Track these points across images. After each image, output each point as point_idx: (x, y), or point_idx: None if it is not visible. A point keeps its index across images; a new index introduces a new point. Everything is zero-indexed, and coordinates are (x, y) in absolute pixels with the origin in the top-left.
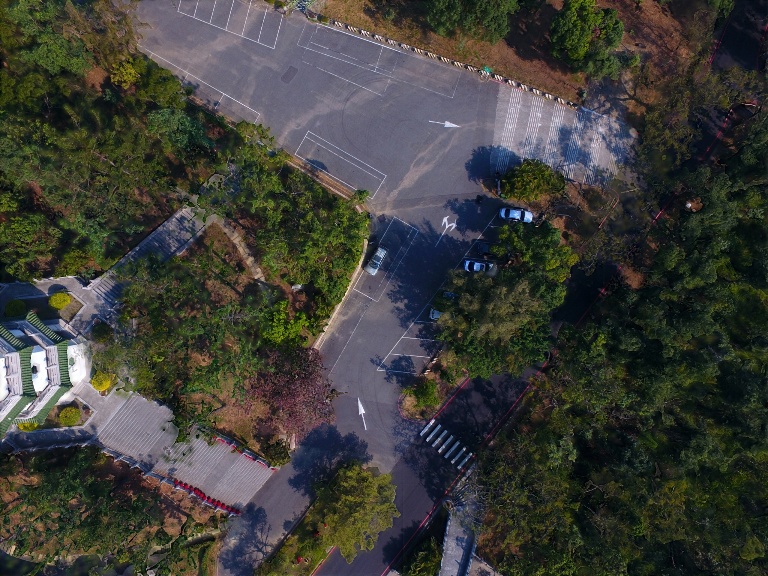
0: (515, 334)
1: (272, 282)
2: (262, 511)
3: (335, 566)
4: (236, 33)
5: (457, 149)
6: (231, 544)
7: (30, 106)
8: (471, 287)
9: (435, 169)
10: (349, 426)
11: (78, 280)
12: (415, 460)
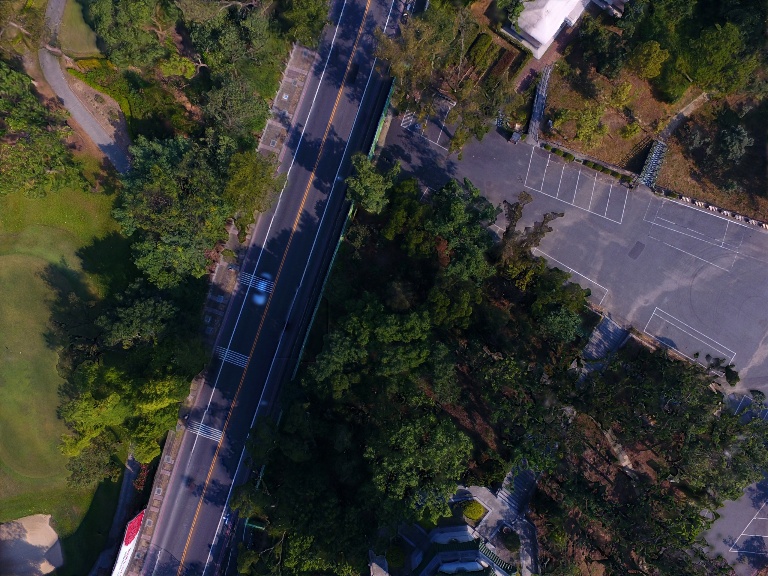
0: None
1: (640, 470)
2: None
3: None
4: (583, 208)
5: None
6: None
7: (463, 325)
8: None
9: None
10: None
11: (487, 488)
12: None
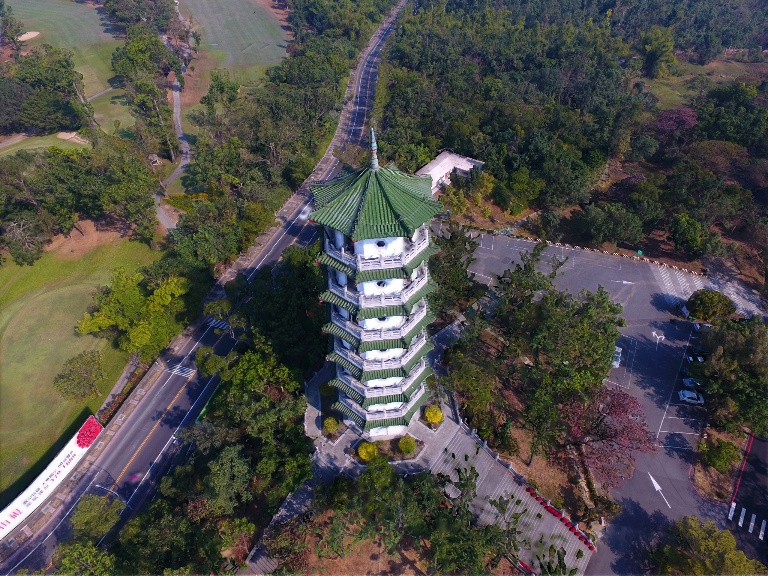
0: None
1: (540, 366)
2: None
3: None
4: None
5: (639, 294)
6: None
7: None
8: (722, 340)
9: (629, 305)
10: (651, 503)
11: None
12: (740, 548)
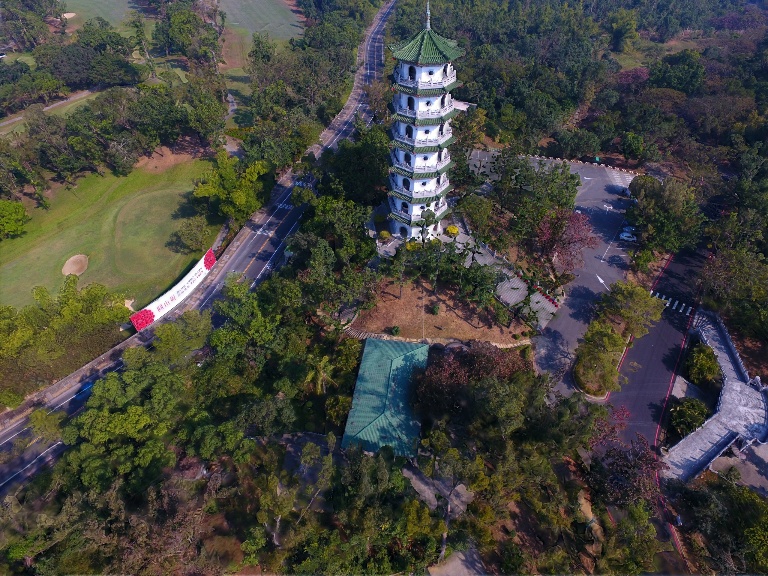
0: (683, 211)
1: None
2: (557, 332)
3: (630, 372)
4: None
5: (596, 185)
6: (542, 353)
7: None
8: None
9: (588, 191)
10: (597, 288)
11: None
12: None
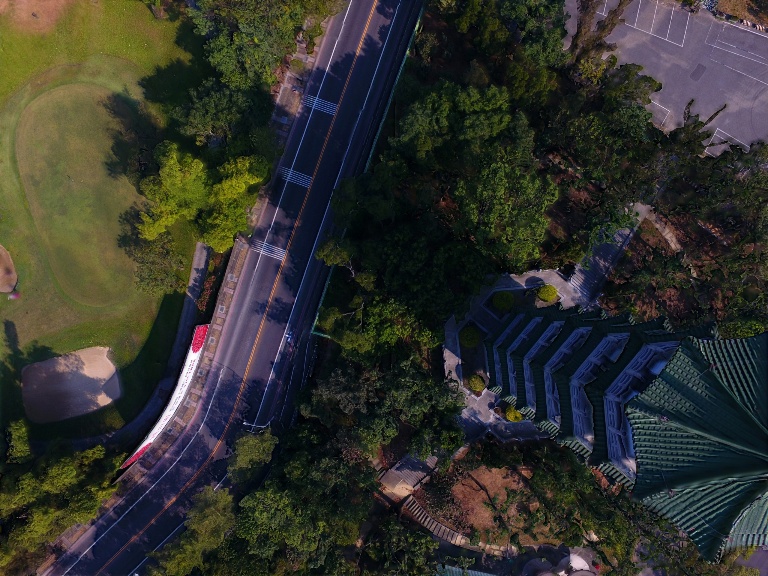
0: None
1: (704, 278)
2: None
3: (744, 562)
4: (645, 30)
5: None
6: None
7: (542, 100)
8: None
9: None
10: None
11: (560, 273)
12: None
